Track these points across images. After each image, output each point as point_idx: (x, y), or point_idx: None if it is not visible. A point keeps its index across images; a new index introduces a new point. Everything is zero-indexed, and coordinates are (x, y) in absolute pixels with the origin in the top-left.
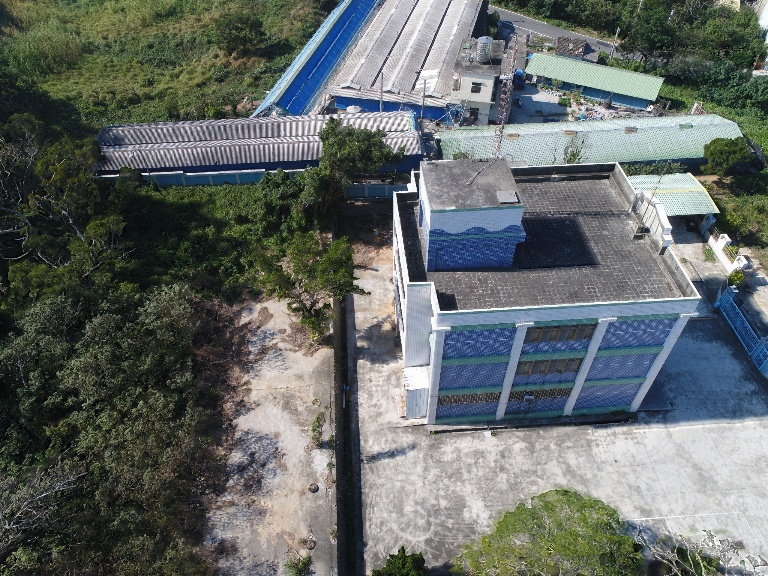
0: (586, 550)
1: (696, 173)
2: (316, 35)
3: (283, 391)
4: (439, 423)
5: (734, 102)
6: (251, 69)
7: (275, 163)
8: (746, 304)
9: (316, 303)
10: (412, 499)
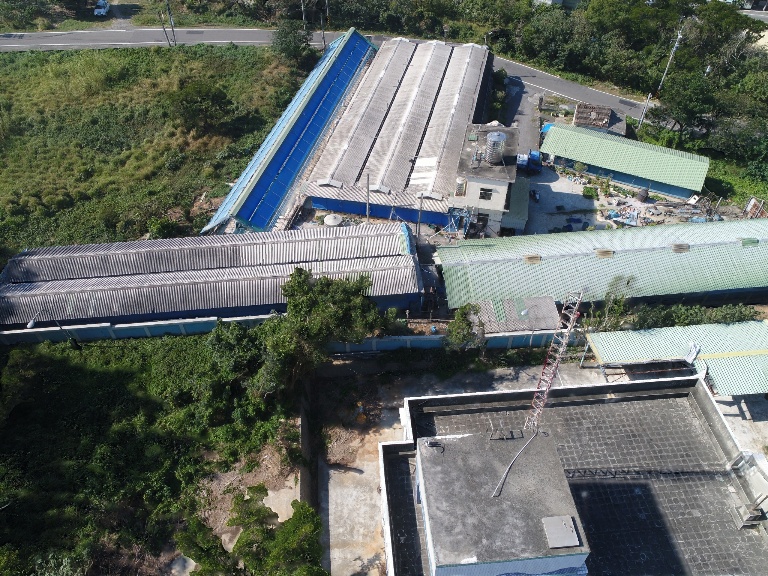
0: None
1: (764, 301)
2: (291, 107)
3: None
4: None
5: None
6: (212, 152)
7: (230, 307)
8: None
9: None
10: None
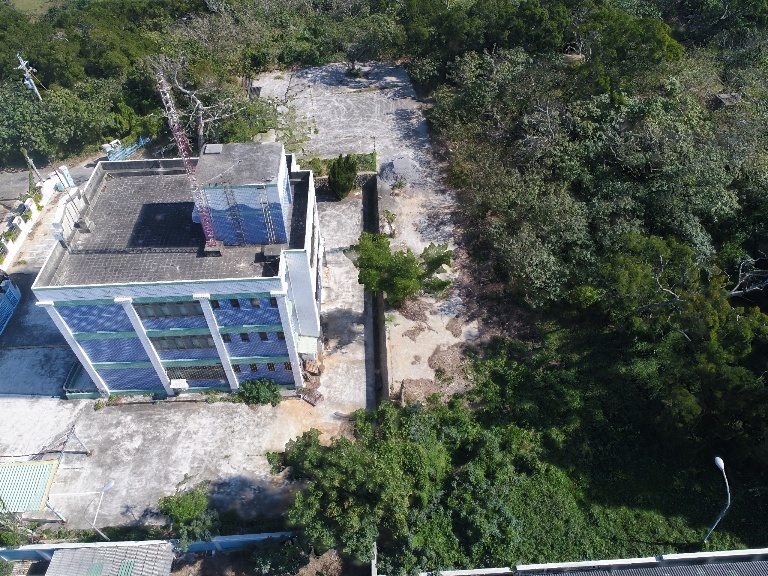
0: (252, 108)
1: None
2: None
3: None
4: None
5: None
6: None
7: None
8: None
9: None
10: (331, 227)
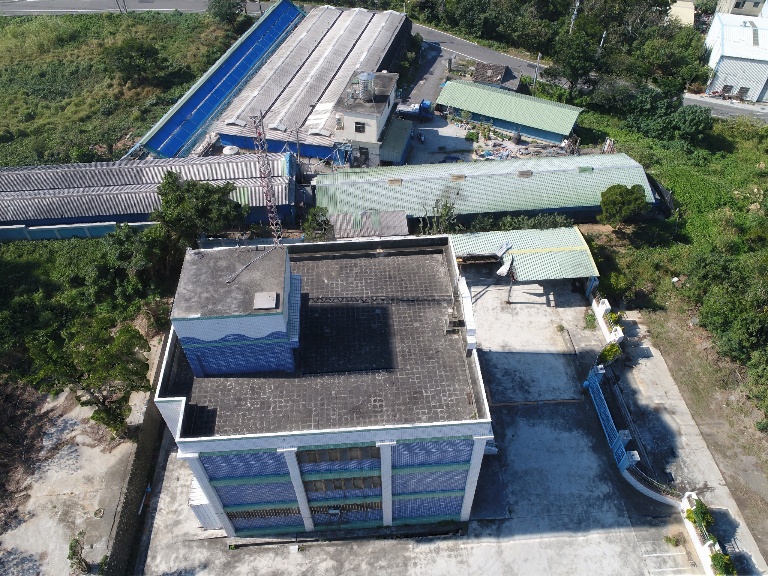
0: None
1: (596, 221)
2: None
3: (65, 498)
4: (241, 535)
5: (661, 133)
6: (143, 100)
7: (128, 215)
8: (622, 381)
9: (113, 394)
10: None
